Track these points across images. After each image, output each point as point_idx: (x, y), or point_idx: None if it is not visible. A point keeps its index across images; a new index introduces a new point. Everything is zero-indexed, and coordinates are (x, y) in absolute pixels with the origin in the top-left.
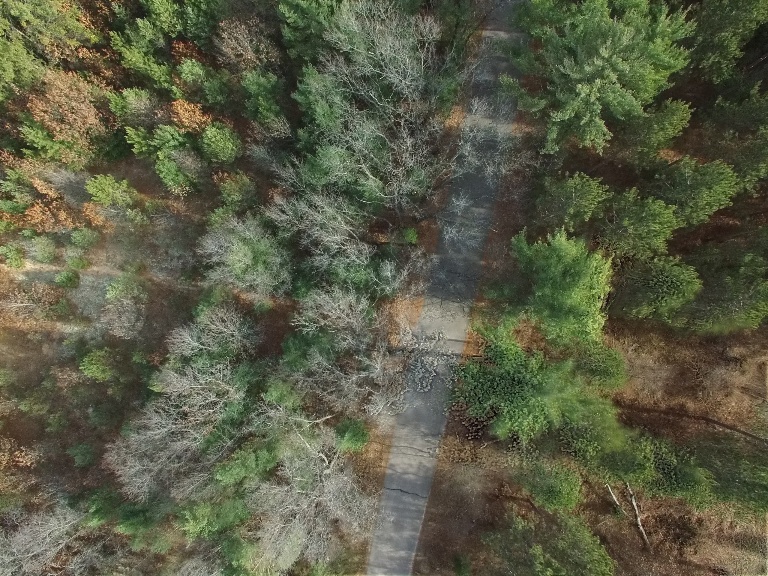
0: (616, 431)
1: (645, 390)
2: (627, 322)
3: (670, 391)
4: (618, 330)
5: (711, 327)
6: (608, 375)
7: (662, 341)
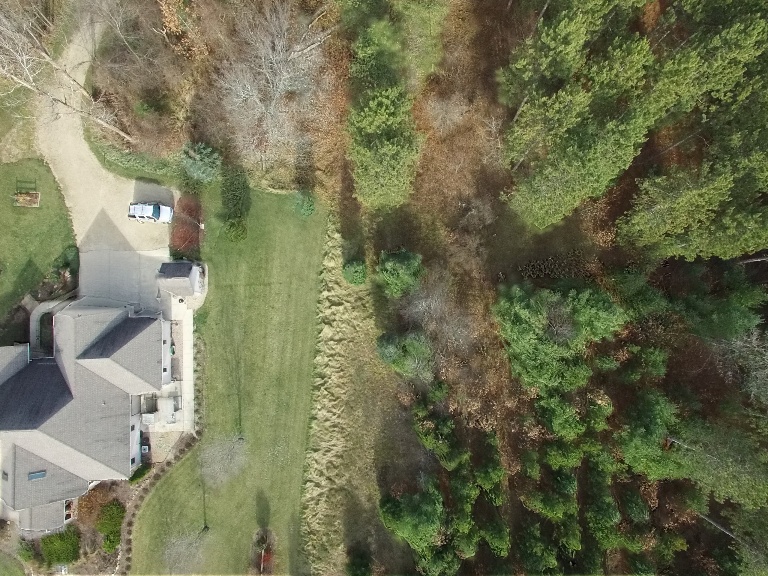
0: (376, 18)
1: (421, 38)
2: (481, 3)
3: (426, 60)
4: (471, 0)
5: (496, 75)
6: (426, 3)
7: (471, 41)
